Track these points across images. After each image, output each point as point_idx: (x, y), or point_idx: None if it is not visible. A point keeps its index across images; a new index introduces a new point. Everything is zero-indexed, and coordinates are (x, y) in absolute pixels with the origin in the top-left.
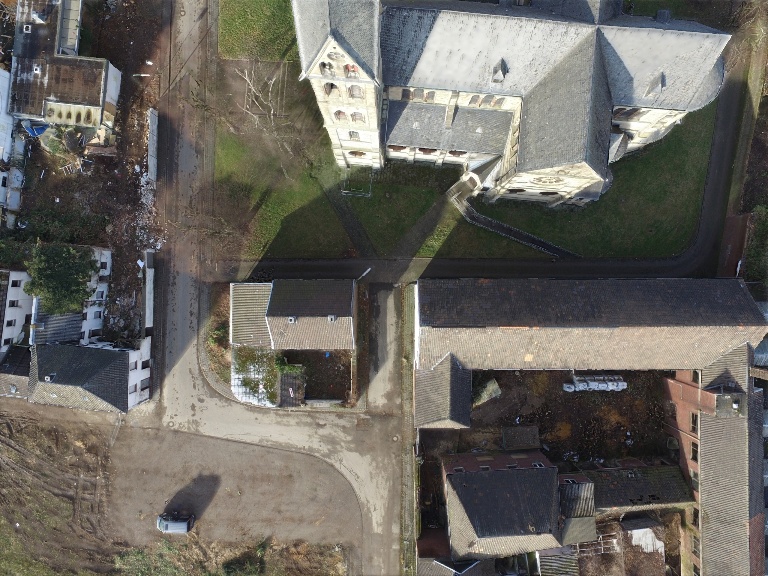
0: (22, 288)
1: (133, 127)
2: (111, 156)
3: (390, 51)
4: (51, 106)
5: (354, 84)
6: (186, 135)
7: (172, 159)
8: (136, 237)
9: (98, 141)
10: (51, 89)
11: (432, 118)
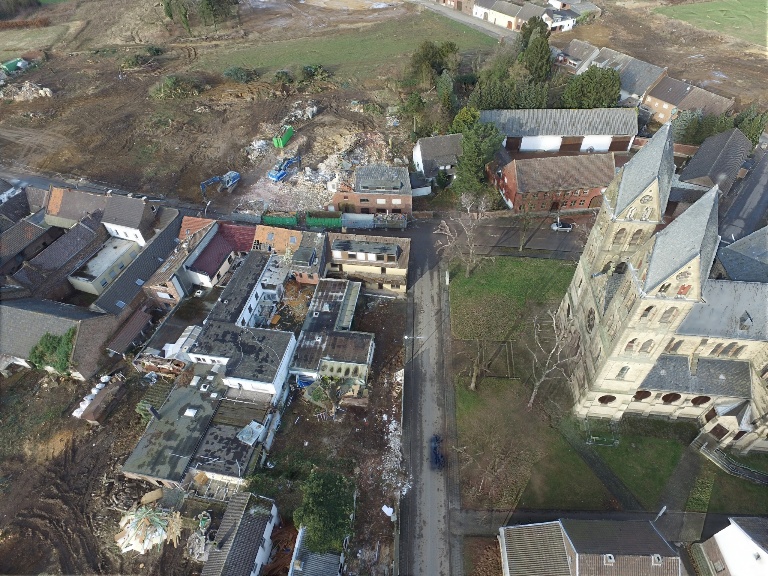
0: (270, 526)
1: (383, 384)
2: (362, 406)
3: None
4: (325, 363)
5: (674, 306)
6: (428, 392)
7: (416, 411)
8: (382, 481)
9: (352, 394)
10: (327, 352)
11: (676, 366)
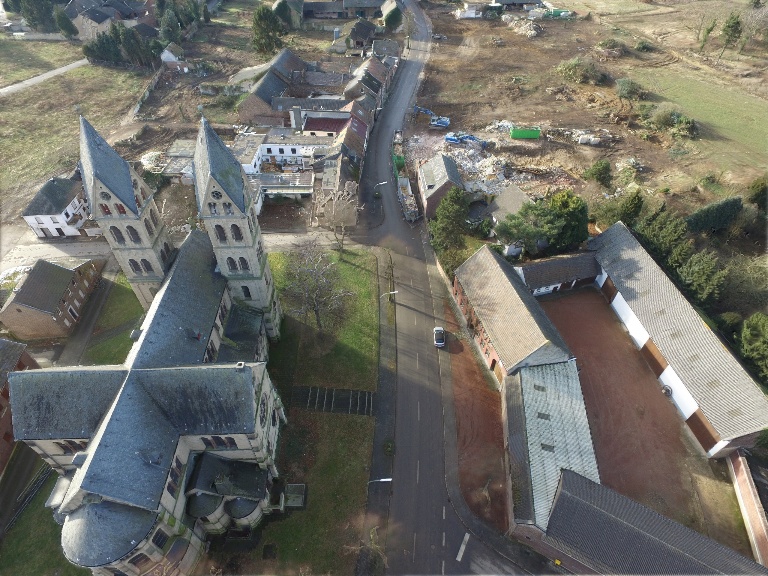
0: None
1: None
2: None
3: None
4: None
5: None
6: None
7: None
8: None
9: None
10: None
11: None
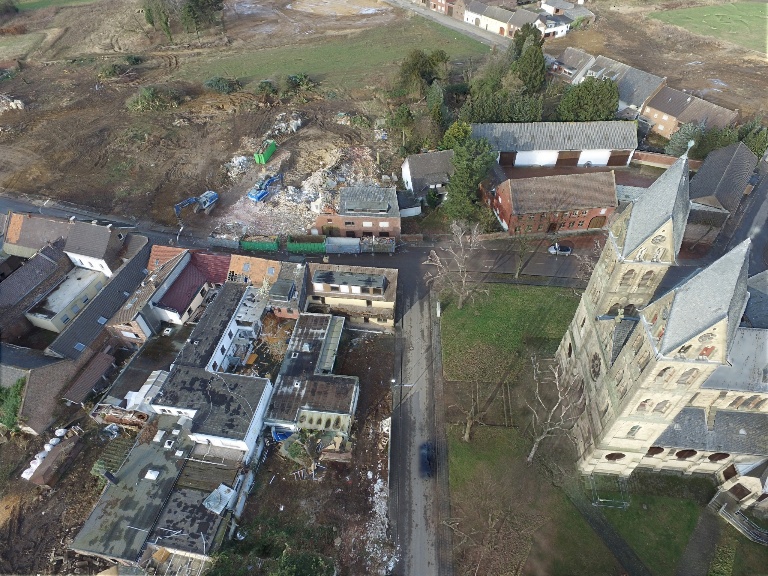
0: None
1: (368, 435)
2: (344, 462)
3: None
4: (304, 413)
5: (695, 367)
6: (418, 443)
7: (404, 466)
8: (366, 554)
9: (334, 447)
10: (307, 400)
11: (692, 420)
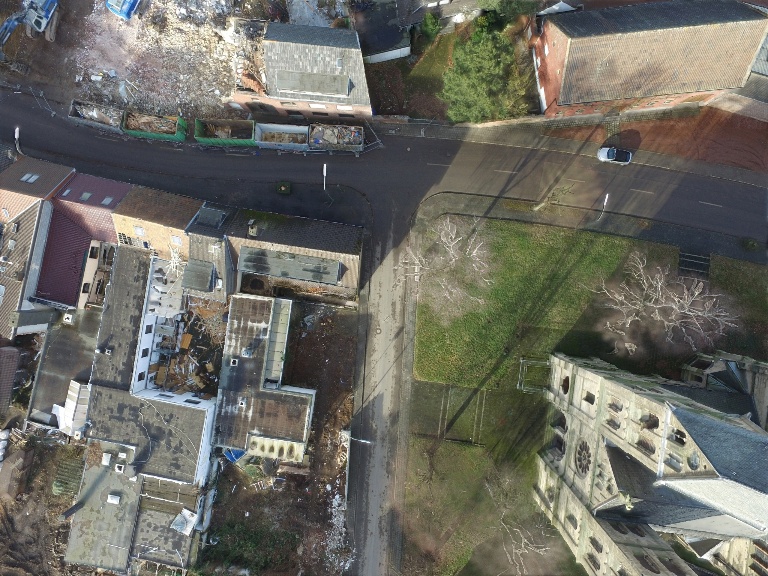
0: None
1: (326, 446)
2: (303, 474)
3: (663, 515)
4: (254, 439)
5: None
6: (378, 455)
7: (363, 478)
8: (325, 557)
9: None
10: (255, 423)
11: None
